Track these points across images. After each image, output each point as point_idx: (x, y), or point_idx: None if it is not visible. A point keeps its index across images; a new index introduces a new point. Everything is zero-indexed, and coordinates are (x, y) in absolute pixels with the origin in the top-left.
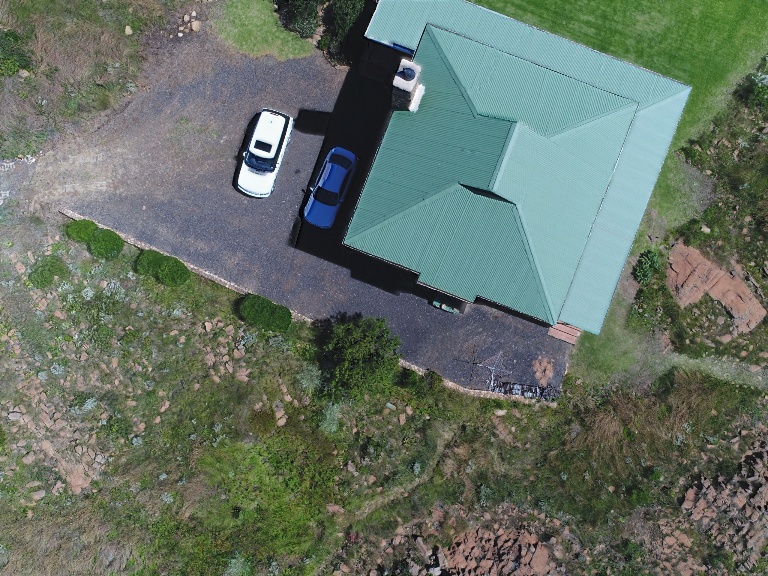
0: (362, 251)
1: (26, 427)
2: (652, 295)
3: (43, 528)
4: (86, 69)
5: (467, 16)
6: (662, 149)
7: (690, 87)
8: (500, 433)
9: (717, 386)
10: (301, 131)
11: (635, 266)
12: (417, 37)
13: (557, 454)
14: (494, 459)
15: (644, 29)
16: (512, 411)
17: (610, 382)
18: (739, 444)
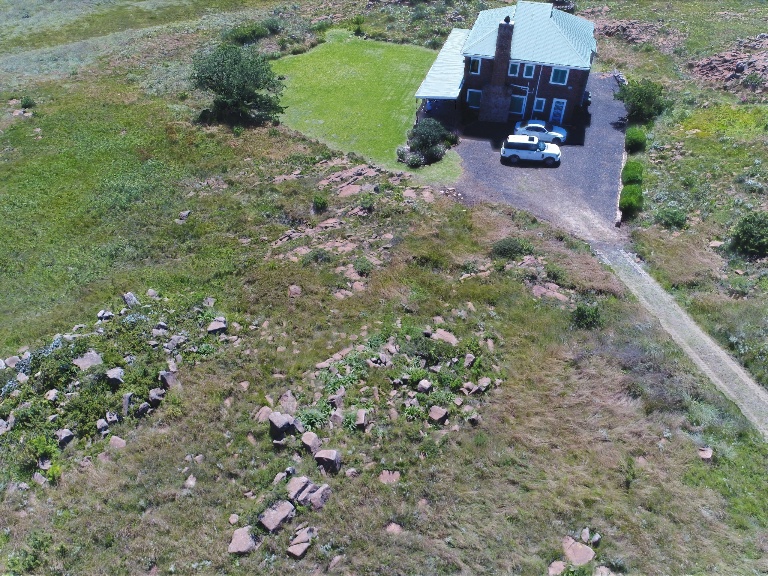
0: None
1: None
2: None
3: None
4: None
5: None
6: None
7: None
8: None
9: None
10: None
11: None
12: (452, 84)
13: None
14: None
15: (409, 68)
16: None
17: None
18: None
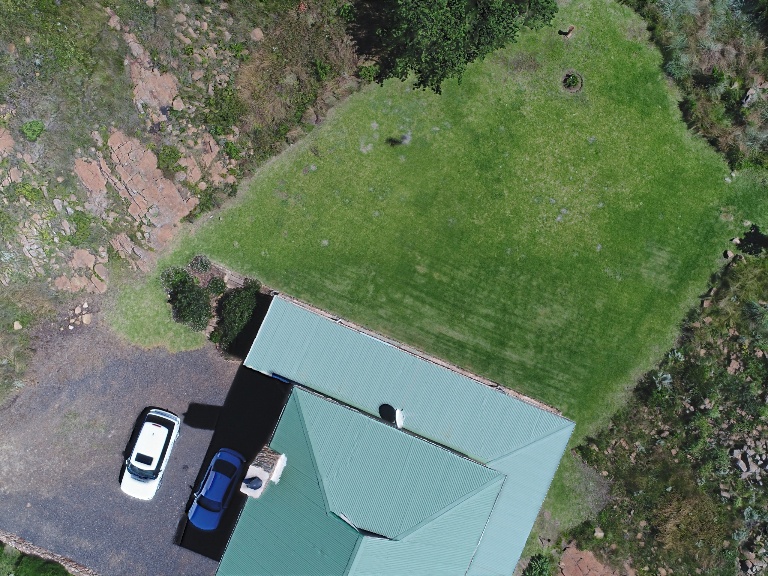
0: None
1: None
2: None
3: None
4: None
5: (349, 344)
6: (543, 486)
7: (574, 423)
8: None
9: None
10: (191, 425)
11: (525, 570)
12: (297, 366)
13: None
14: None
15: (545, 323)
16: None
17: None
18: None
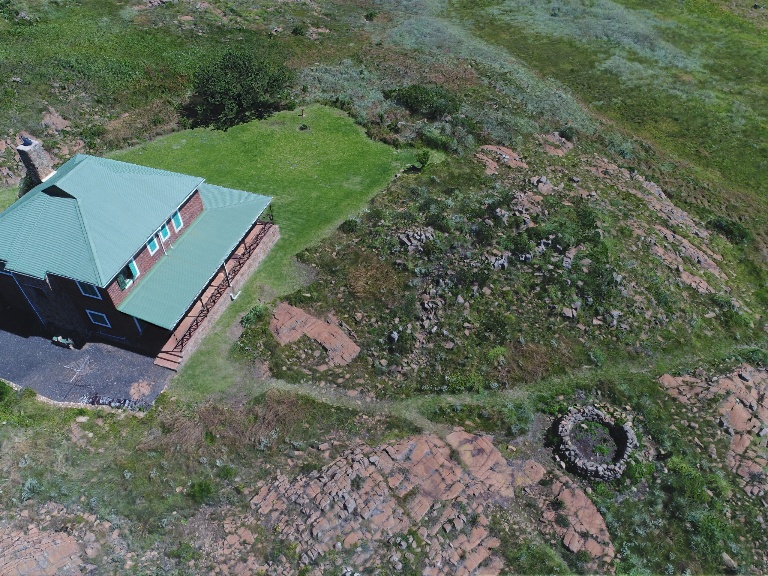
0: None
1: None
2: (254, 334)
3: None
4: None
5: None
6: (246, 224)
7: (271, 197)
8: (74, 436)
9: (308, 401)
10: None
11: None
12: None
13: (129, 457)
14: (57, 458)
15: (276, 202)
16: (96, 420)
17: (205, 401)
18: (330, 452)
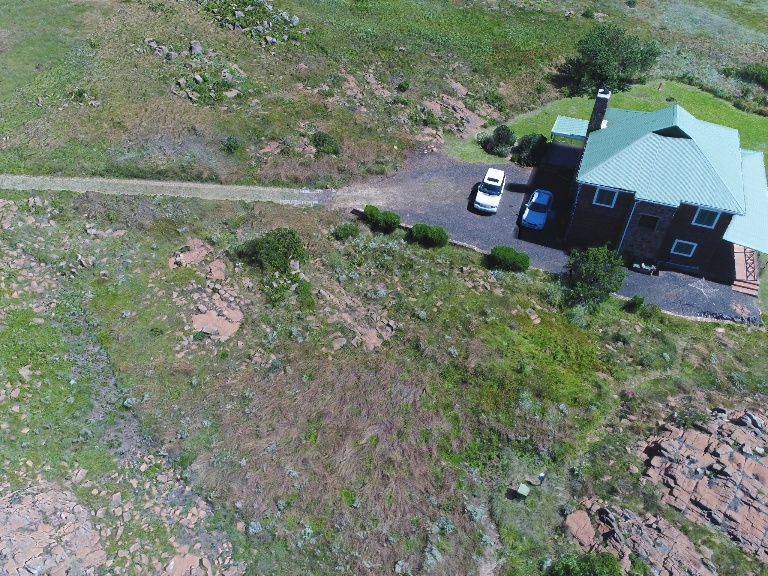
0: (591, 183)
1: (331, 301)
2: None
3: (343, 367)
4: (372, 156)
5: None
6: (761, 174)
7: (761, 152)
8: (727, 343)
9: None
10: (508, 191)
11: None
12: (583, 133)
13: None
14: (732, 359)
15: None
16: (729, 332)
17: None
18: None
